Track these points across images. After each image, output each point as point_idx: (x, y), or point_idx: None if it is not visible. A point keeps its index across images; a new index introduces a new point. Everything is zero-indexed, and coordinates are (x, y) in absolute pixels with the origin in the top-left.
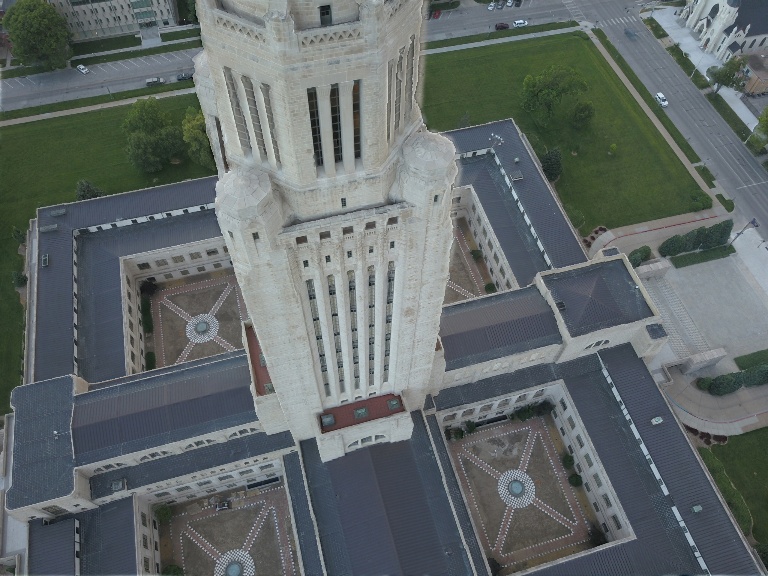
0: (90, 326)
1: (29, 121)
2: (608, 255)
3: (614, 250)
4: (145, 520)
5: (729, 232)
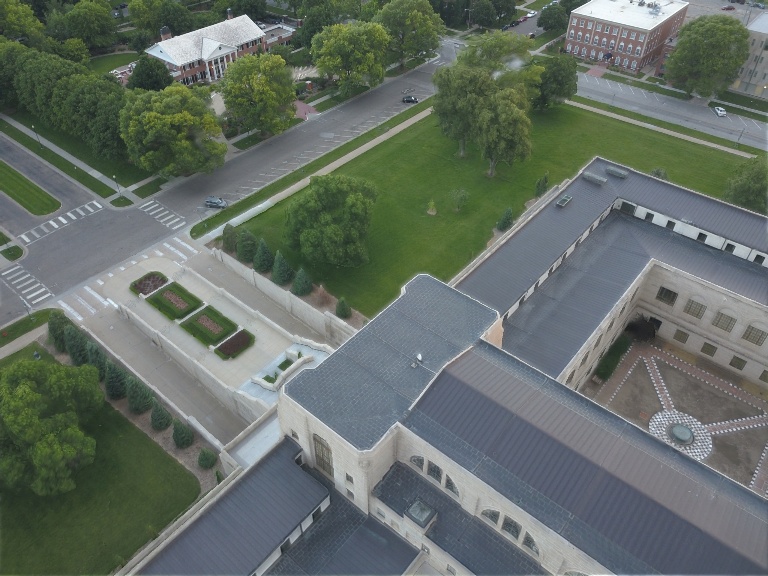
0: (552, 299)
1: (628, 121)
2: None
3: None
4: None
5: None
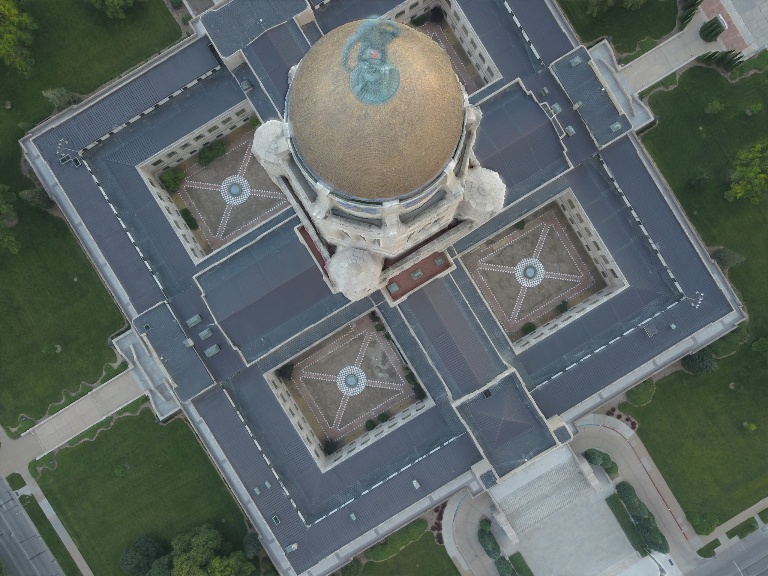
0: None
1: None
2: (561, 431)
3: (569, 436)
4: (242, 113)
5: (658, 550)
